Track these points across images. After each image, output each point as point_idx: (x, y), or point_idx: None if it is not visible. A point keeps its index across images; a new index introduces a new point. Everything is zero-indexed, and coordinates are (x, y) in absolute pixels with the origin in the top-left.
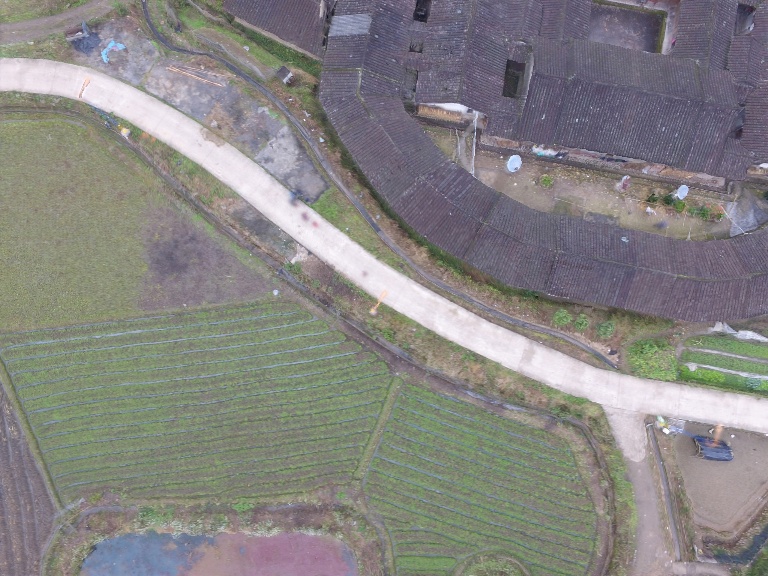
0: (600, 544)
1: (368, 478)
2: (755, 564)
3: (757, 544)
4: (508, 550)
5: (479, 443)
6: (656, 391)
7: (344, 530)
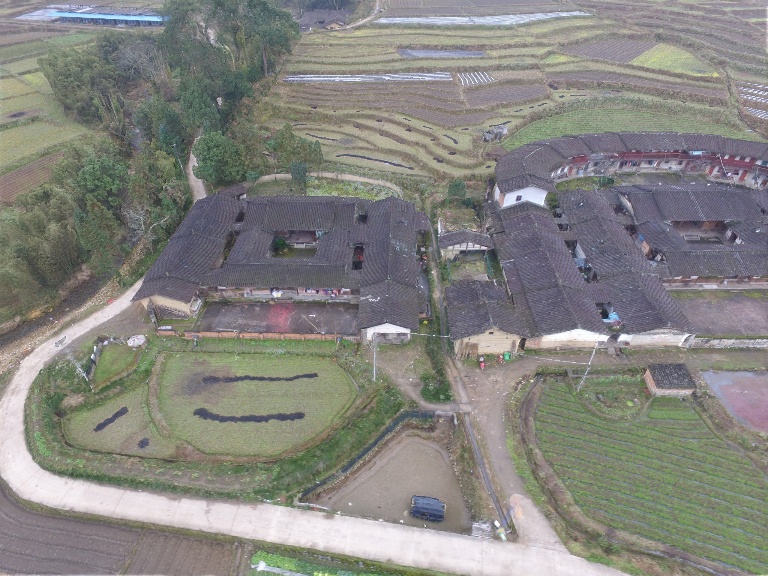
0: (533, 426)
1: (766, 483)
2: (396, 411)
3: (394, 425)
4: (608, 423)
5: (675, 515)
6: (511, 570)
7: (761, 439)
